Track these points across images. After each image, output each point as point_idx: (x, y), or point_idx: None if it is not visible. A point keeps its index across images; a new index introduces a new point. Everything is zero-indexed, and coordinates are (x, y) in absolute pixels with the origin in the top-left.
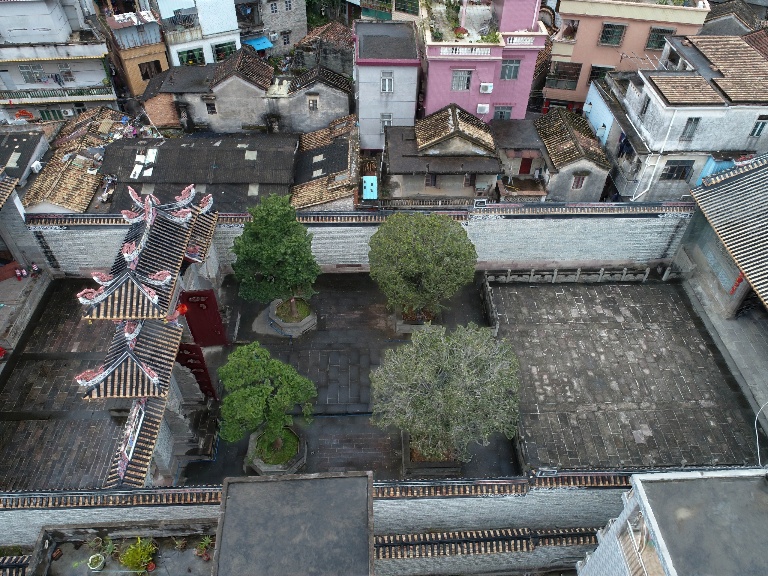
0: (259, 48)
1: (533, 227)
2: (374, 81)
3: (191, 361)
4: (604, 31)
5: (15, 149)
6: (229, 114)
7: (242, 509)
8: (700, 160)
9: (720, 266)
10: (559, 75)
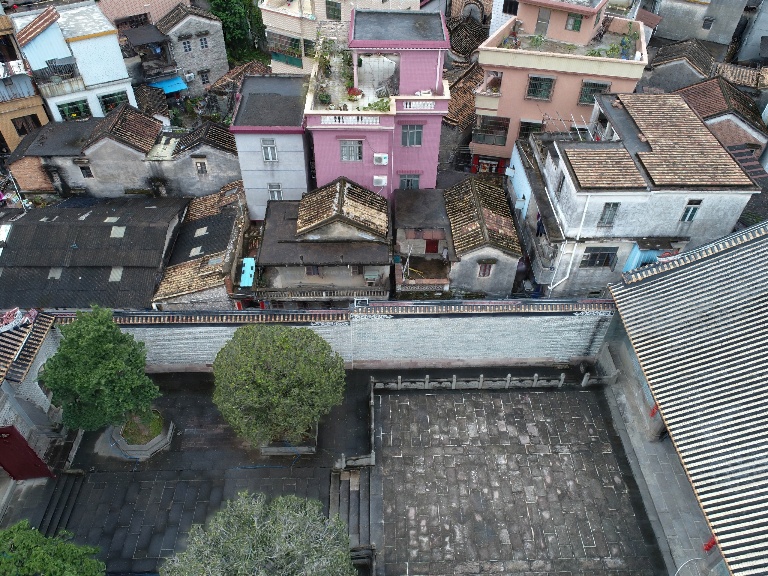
0: (170, 90)
1: (428, 326)
2: (254, 149)
3: (3, 501)
4: (530, 84)
5: None
6: (108, 178)
7: None
8: (624, 247)
9: None
10: (486, 130)
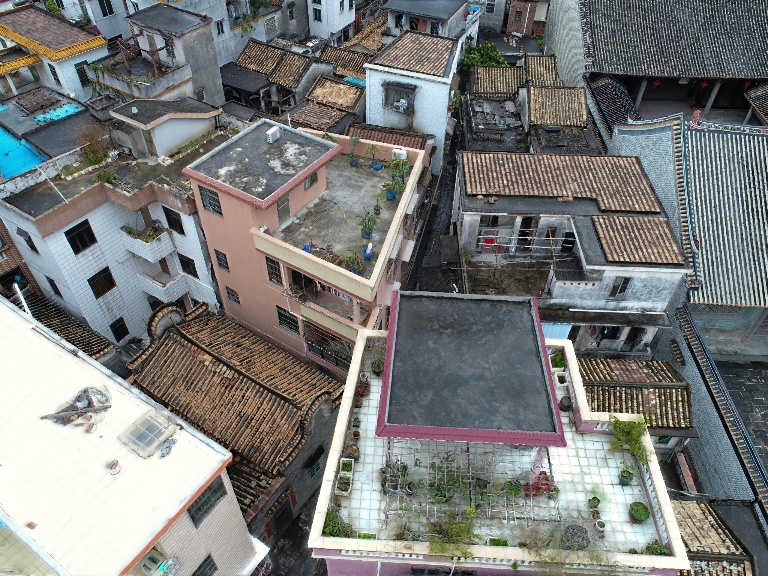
0: None
1: None
2: None
3: None
4: (394, 265)
5: None
6: None
7: None
8: None
9: (715, 320)
10: None
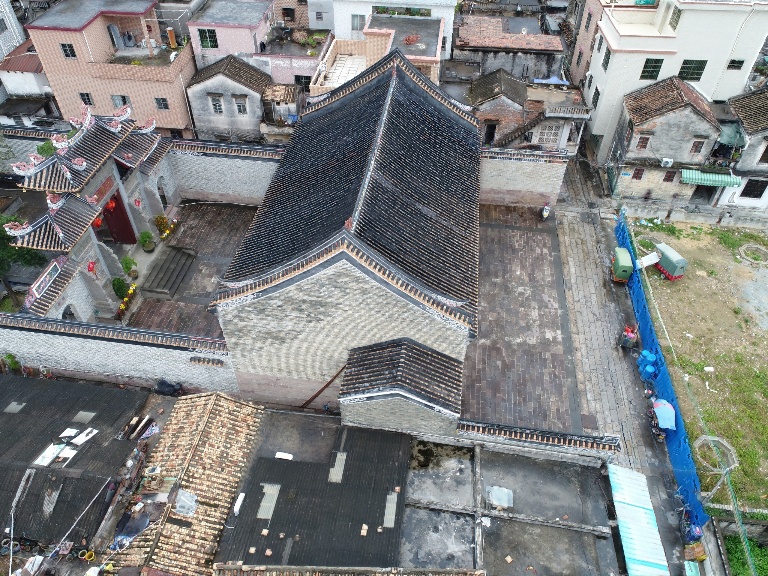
0: None
1: None
2: None
3: None
4: None
5: (268, 527)
6: None
7: (78, 24)
8: None
9: None
10: None
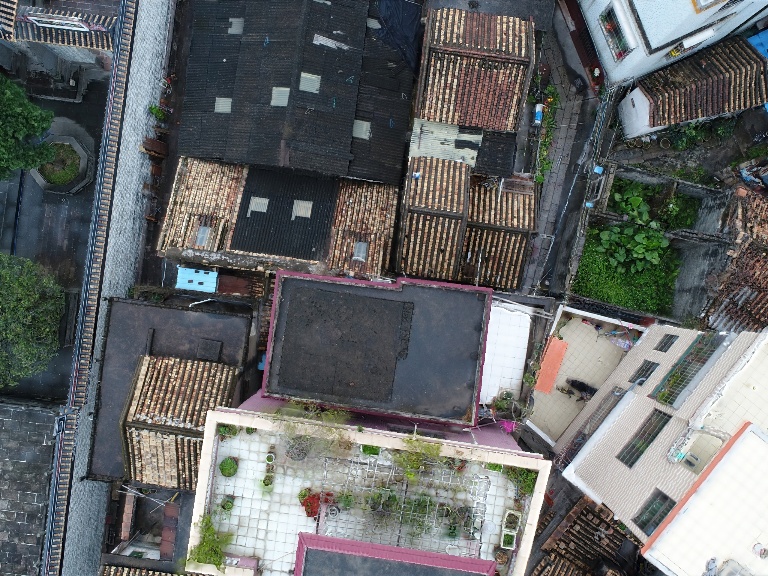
0: None
1: None
2: None
3: None
4: None
5: None
6: None
7: None
8: None
9: None
10: None
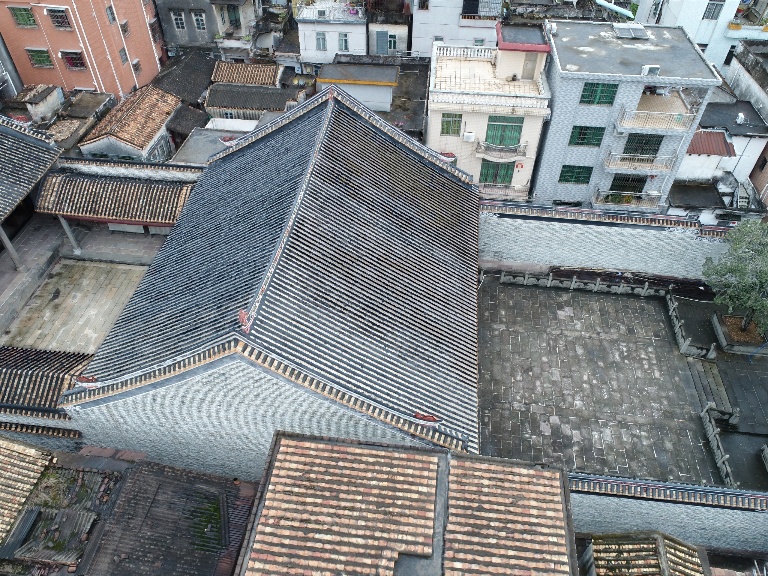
0: None
1: None
2: None
3: None
4: None
5: None
6: None
7: None
8: None
9: None
10: None
